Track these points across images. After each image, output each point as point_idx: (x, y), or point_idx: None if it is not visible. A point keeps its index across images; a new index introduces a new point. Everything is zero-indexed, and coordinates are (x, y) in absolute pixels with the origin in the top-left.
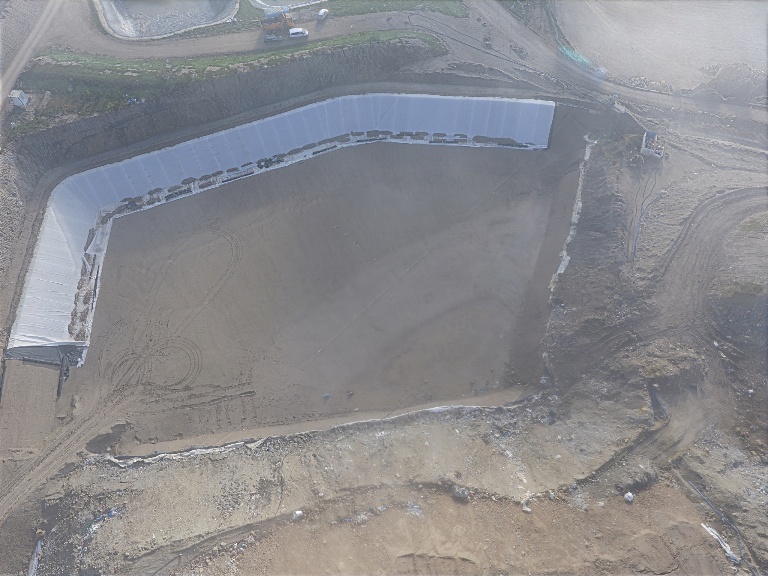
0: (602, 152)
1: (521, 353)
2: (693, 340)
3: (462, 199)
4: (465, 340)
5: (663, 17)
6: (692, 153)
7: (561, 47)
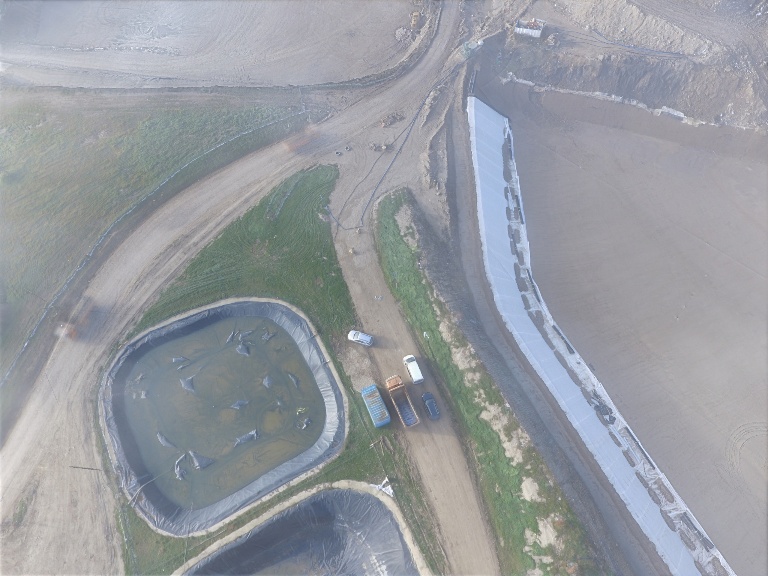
0: (532, 68)
1: (767, 153)
2: (761, 26)
3: (598, 195)
4: (767, 197)
5: (290, 5)
6: (530, 3)
7: (376, 83)
